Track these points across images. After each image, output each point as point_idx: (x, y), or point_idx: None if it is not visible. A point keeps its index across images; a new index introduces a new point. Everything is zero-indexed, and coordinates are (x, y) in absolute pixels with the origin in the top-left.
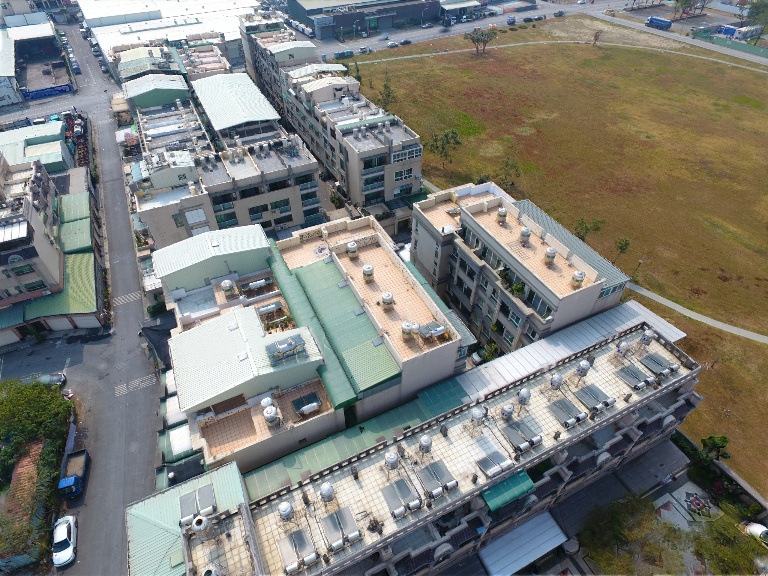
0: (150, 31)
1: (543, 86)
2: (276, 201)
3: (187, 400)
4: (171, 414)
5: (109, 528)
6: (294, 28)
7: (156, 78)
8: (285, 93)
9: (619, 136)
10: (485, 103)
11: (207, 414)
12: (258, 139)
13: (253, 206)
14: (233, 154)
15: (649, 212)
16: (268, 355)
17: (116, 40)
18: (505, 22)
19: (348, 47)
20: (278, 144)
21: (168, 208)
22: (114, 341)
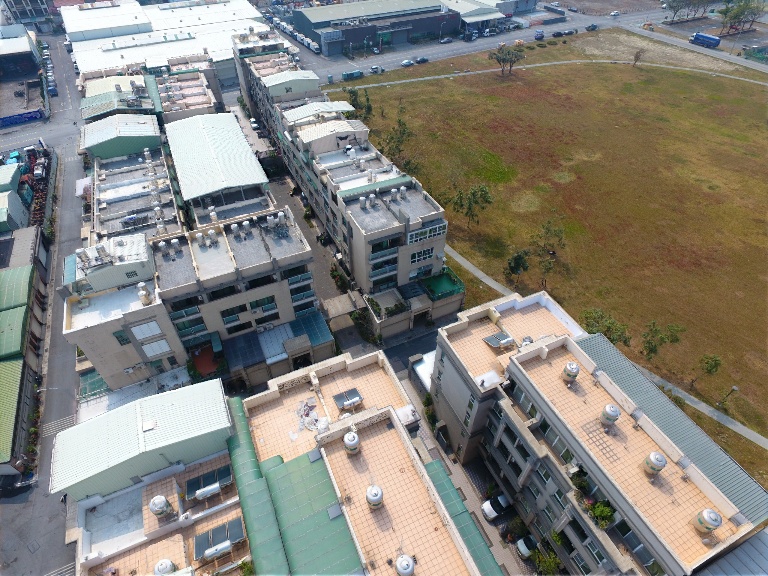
0: (136, 48)
1: (580, 117)
2: (257, 299)
3: None
4: None
5: None
6: (299, 42)
7: (122, 120)
8: (281, 133)
9: (676, 186)
10: (514, 139)
11: None
12: (239, 208)
13: (226, 308)
14: (203, 236)
15: (727, 298)
16: None
17: (96, 59)
18: (532, 37)
19: (358, 66)
20: (263, 218)
21: (106, 325)
22: (34, 498)
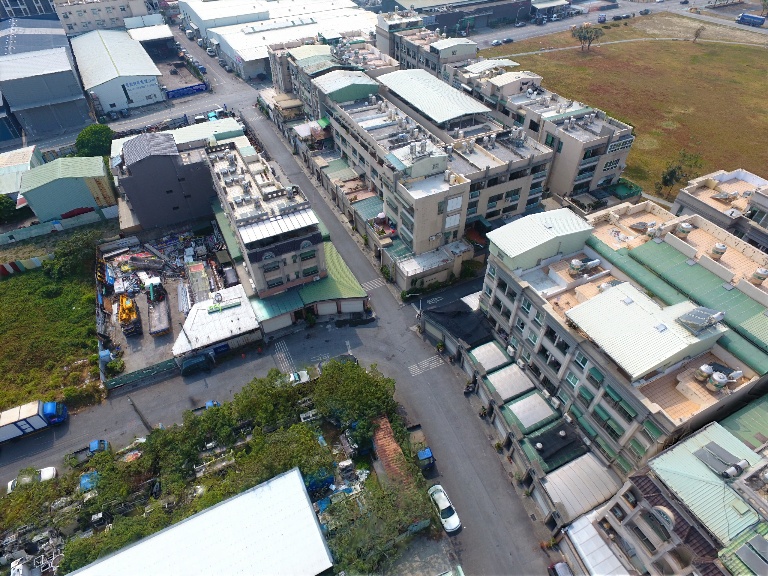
0: (271, 31)
1: (664, 82)
2: (511, 190)
3: (632, 367)
4: (500, 390)
5: (477, 497)
6: None
7: (344, 74)
8: None
9: (766, 129)
10: (616, 98)
11: (640, 381)
12: (470, 131)
13: (493, 195)
14: (467, 145)
15: None
16: (686, 326)
17: (243, 40)
18: (595, 20)
19: None
20: (498, 135)
21: (438, 195)
22: (382, 325)
